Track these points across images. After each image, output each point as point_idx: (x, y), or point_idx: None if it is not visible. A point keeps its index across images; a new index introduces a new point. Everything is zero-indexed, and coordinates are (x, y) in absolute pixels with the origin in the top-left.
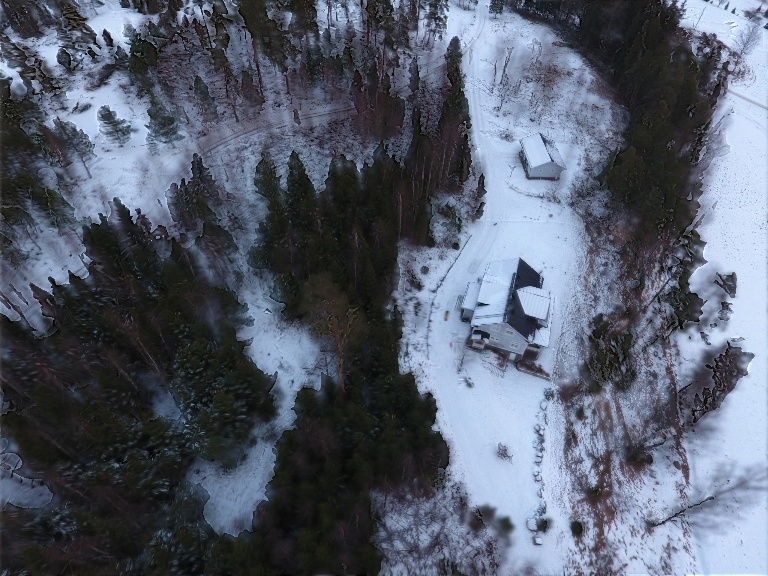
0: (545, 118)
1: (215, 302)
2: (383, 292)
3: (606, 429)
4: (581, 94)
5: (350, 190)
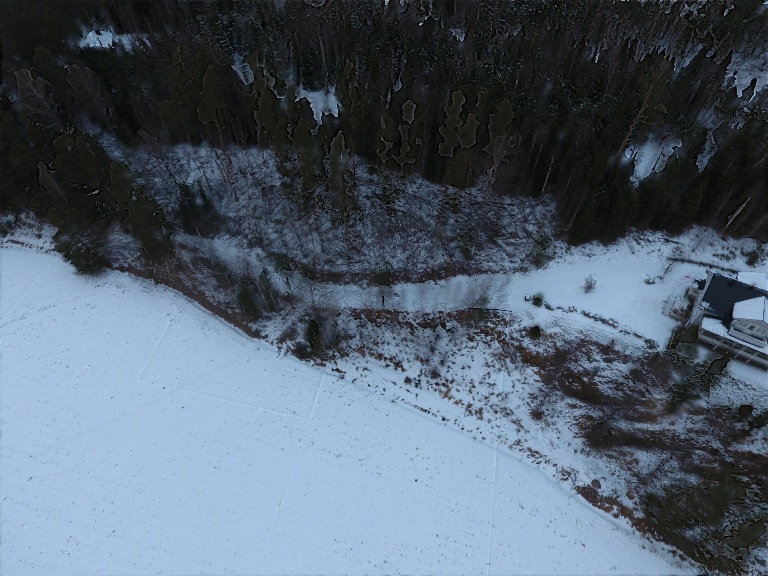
0: None
1: (668, 105)
2: (719, 202)
3: (626, 410)
4: None
5: None
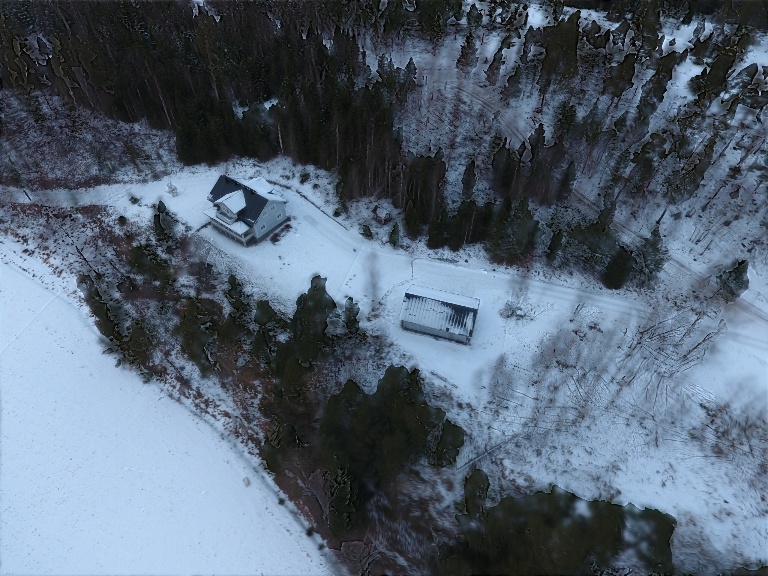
0: (569, 385)
1: None
2: None
3: None
4: (664, 488)
5: (353, 106)
